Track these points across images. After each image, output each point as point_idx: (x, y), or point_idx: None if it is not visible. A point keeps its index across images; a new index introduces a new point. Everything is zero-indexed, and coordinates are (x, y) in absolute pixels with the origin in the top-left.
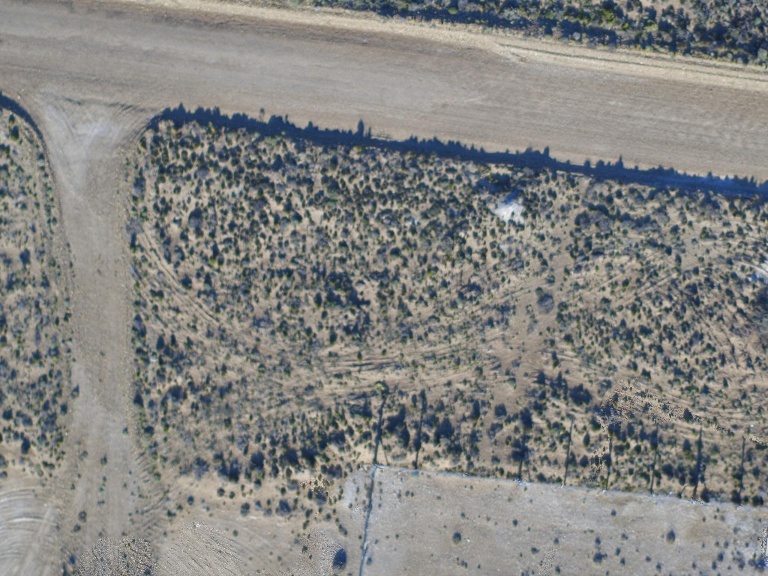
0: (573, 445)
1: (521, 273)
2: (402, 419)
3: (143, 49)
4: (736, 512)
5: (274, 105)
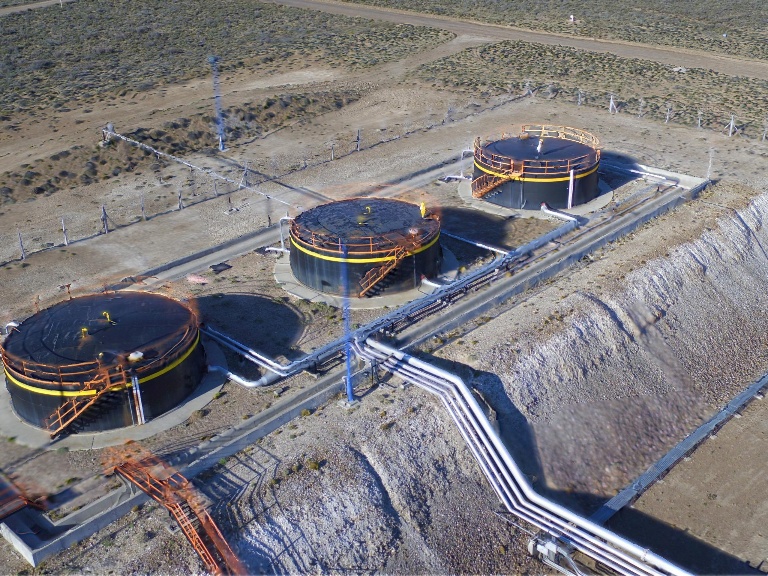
0: (659, 110)
1: (671, 81)
2: (558, 89)
3: (525, 36)
4: (761, 142)
5: (575, 47)
